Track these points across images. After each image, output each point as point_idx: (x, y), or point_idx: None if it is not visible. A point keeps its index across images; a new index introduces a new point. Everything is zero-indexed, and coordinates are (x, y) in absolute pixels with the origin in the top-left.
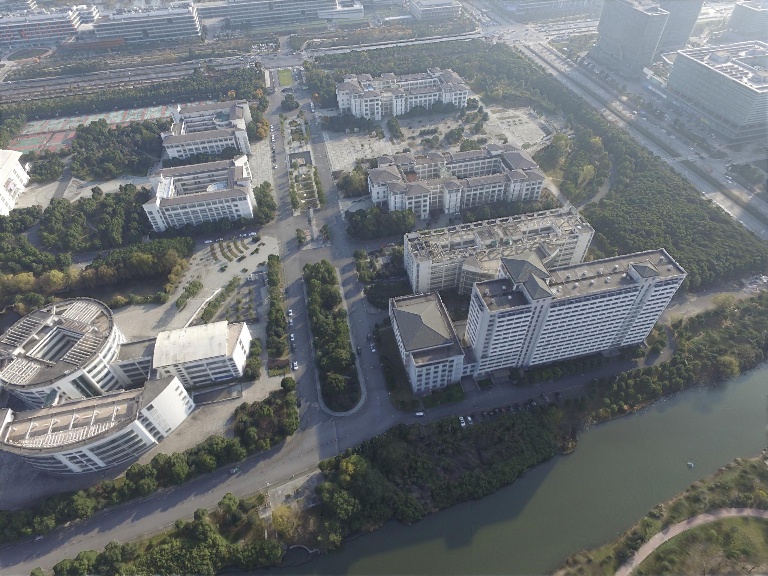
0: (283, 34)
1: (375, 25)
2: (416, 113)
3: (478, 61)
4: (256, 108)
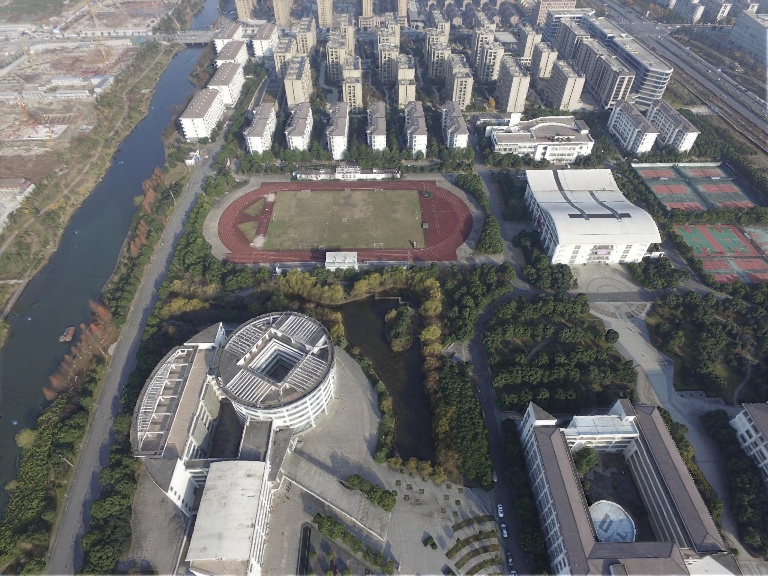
0: None
1: None
2: None
3: None
4: None
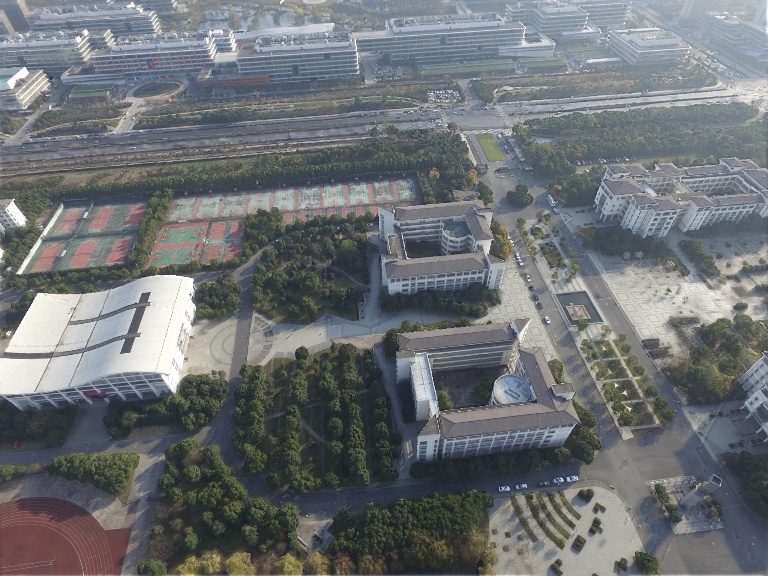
0: (460, 76)
1: (573, 68)
2: (721, 231)
3: (765, 141)
4: None
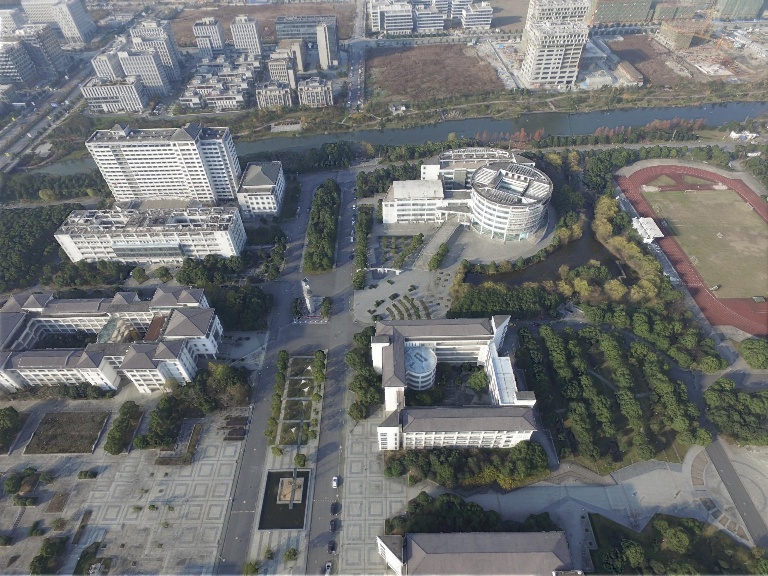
0: None
1: None
2: None
3: None
4: None
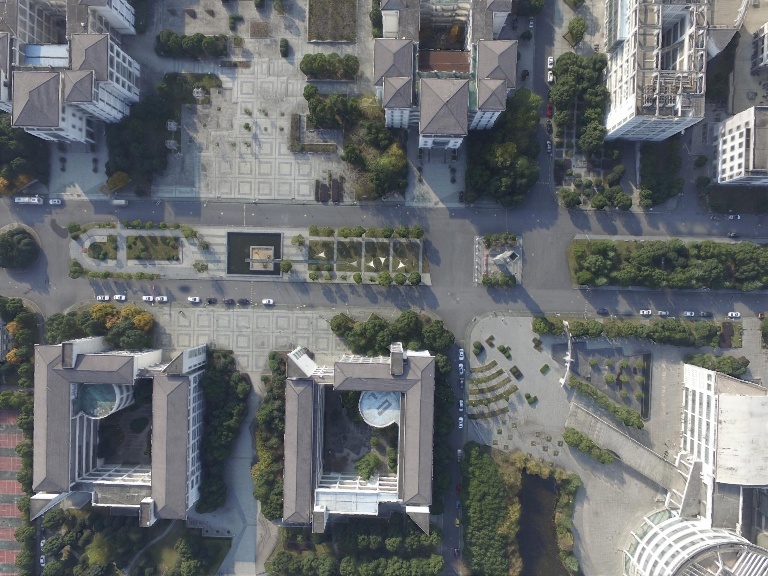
0: None
1: None
2: None
3: None
4: (20, 325)
